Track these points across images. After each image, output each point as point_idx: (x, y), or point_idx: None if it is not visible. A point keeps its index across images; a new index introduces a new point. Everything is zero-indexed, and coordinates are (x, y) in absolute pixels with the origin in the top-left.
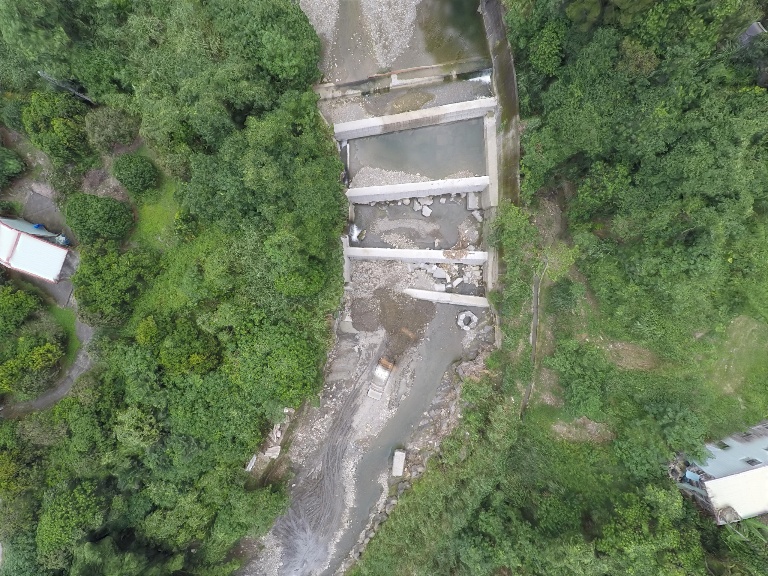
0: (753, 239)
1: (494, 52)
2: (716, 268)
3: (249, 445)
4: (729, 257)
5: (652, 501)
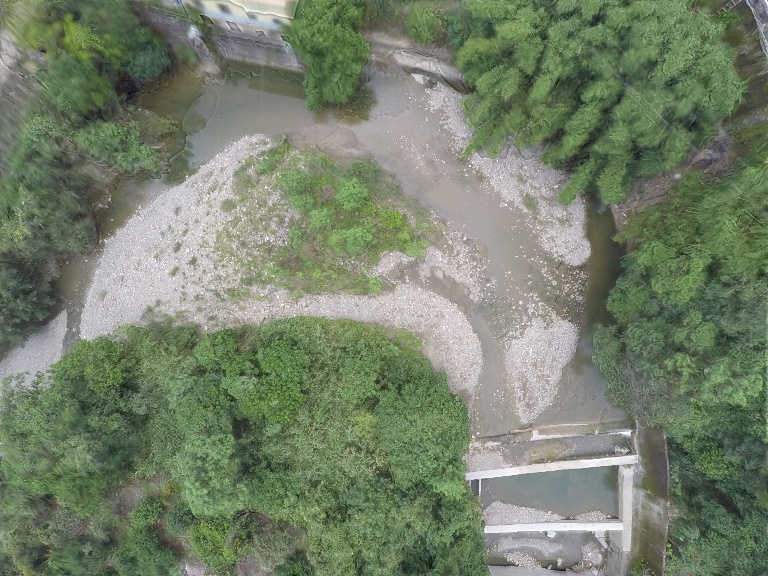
0: None
1: (641, 421)
2: None
3: None
4: None
5: None
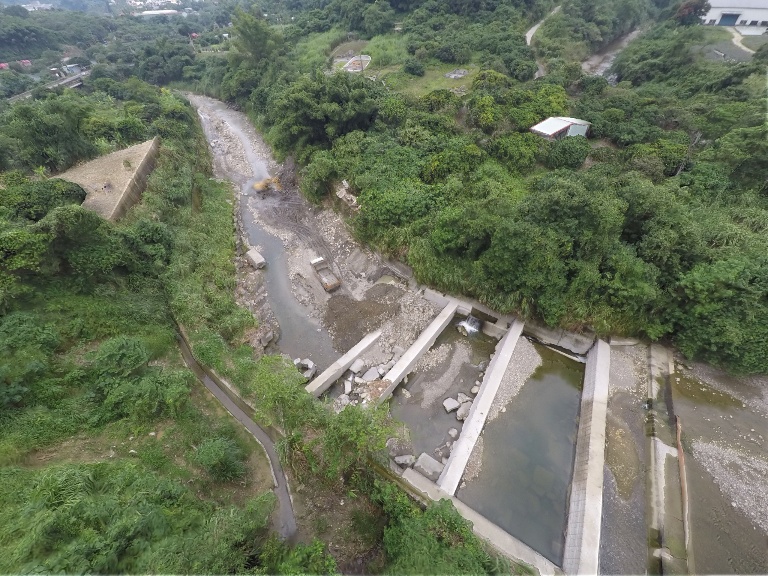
0: None
1: None
2: None
3: None
4: None
5: None
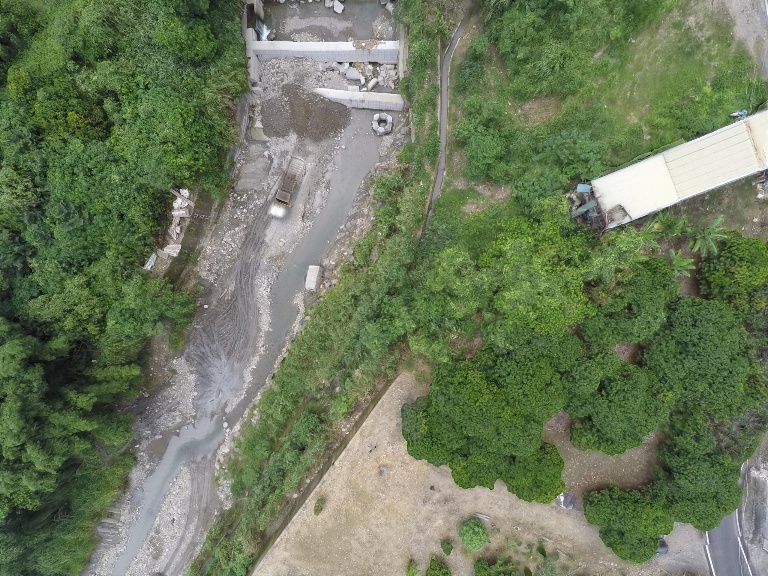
0: None
1: None
2: None
3: (140, 228)
4: None
5: (538, 213)
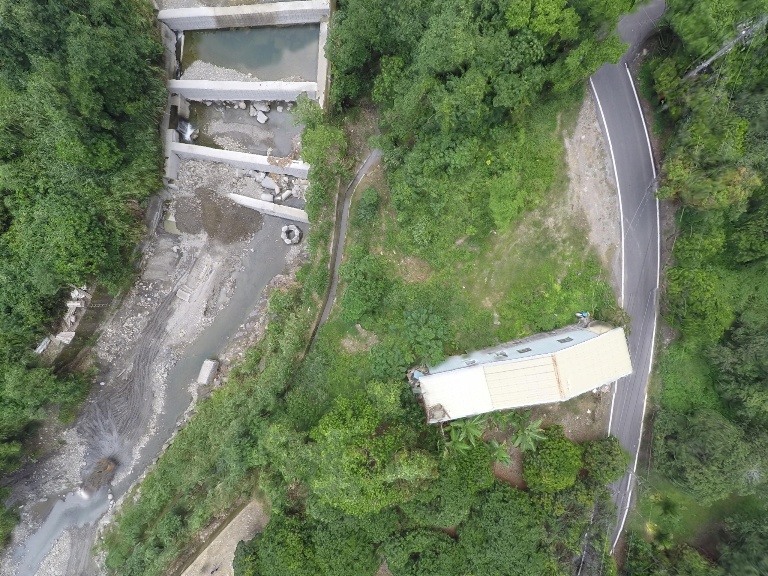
0: (513, 143)
1: None
2: (461, 162)
3: (29, 320)
4: (487, 159)
5: (372, 394)
